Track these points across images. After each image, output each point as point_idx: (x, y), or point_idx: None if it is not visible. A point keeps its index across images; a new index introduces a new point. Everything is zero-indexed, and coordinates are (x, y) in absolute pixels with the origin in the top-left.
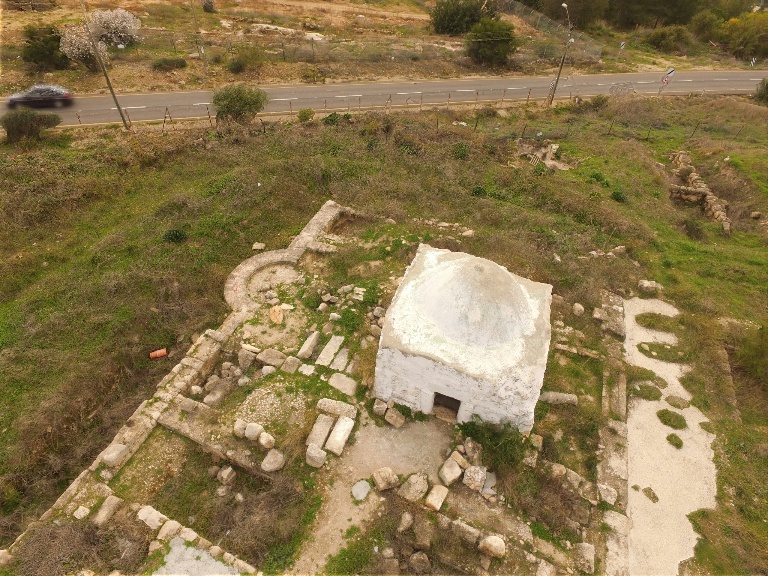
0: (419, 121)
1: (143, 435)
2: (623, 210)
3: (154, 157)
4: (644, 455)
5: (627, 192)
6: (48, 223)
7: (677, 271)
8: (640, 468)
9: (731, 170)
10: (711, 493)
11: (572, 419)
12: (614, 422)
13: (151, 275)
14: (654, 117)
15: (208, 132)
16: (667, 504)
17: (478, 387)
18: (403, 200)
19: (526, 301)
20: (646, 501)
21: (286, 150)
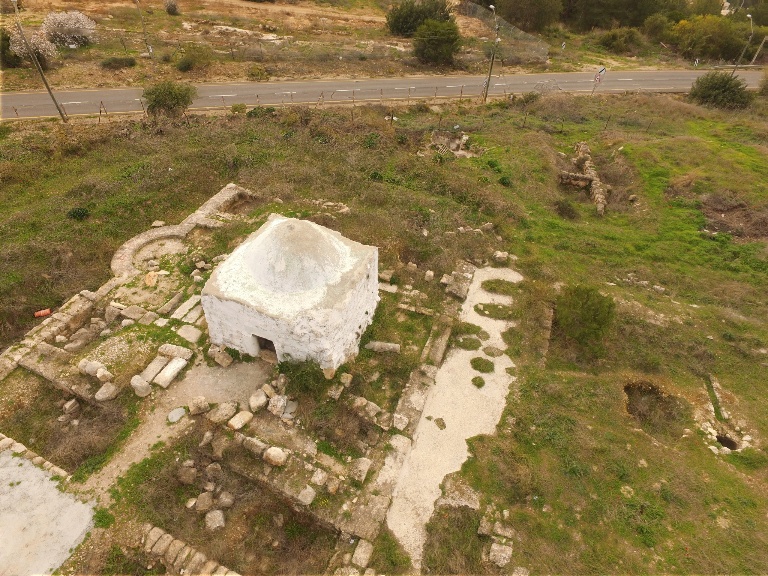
0: (339, 114)
1: (2, 374)
2: (506, 193)
3: (78, 145)
4: (446, 393)
5: (515, 177)
6: None
7: (536, 245)
8: (439, 403)
9: (622, 158)
10: (494, 422)
11: (391, 364)
12: (426, 366)
13: (46, 246)
14: (574, 112)
15: (134, 123)
16: (452, 431)
17: (277, 326)
18: (301, 183)
19: (338, 257)
20: (434, 428)
21: (204, 140)
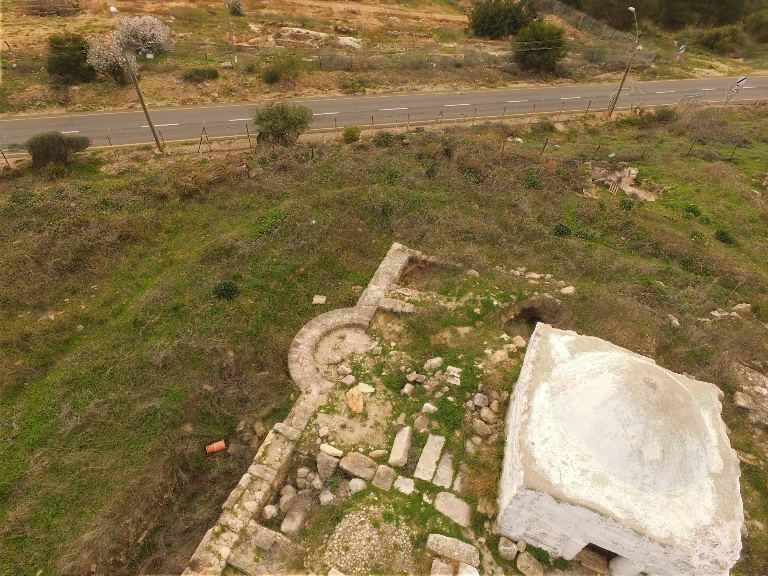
0: (480, 142)
1: None
2: (733, 254)
3: (194, 188)
4: None
5: (733, 230)
6: (81, 273)
7: None
8: None
9: None
10: None
11: (745, 559)
12: None
13: (203, 344)
14: (732, 133)
15: (251, 157)
16: None
17: (663, 554)
18: (479, 242)
19: None
20: None
21: (339, 178)
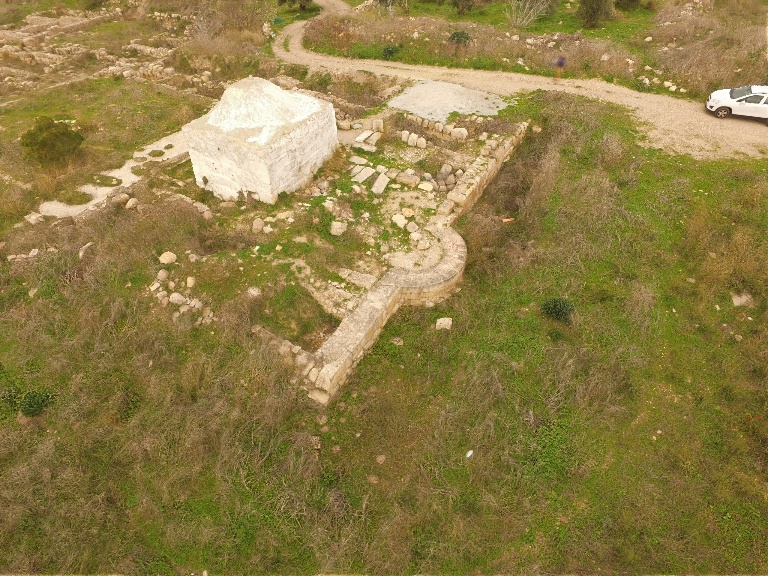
0: None
1: None
2: None
3: None
4: None
5: None
6: None
7: None
8: None
9: None
10: None
11: None
12: None
13: None
14: None
15: None
16: None
17: None
18: None
19: None
20: None
21: None
